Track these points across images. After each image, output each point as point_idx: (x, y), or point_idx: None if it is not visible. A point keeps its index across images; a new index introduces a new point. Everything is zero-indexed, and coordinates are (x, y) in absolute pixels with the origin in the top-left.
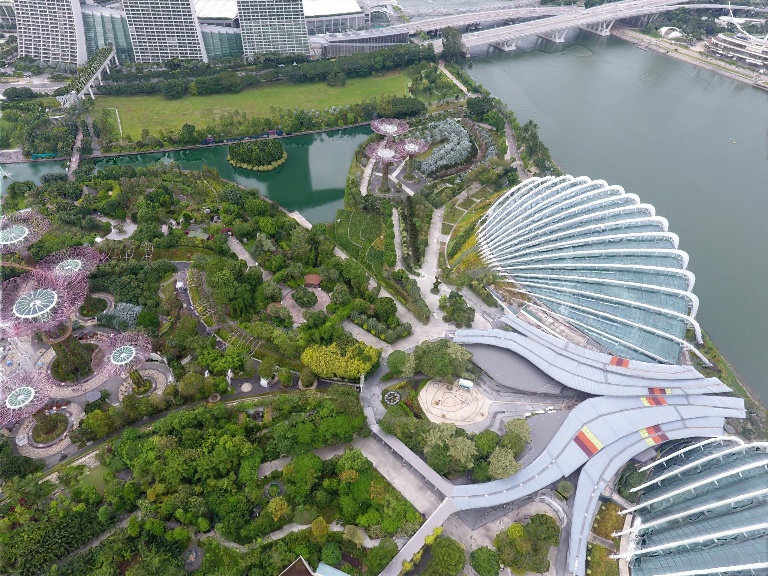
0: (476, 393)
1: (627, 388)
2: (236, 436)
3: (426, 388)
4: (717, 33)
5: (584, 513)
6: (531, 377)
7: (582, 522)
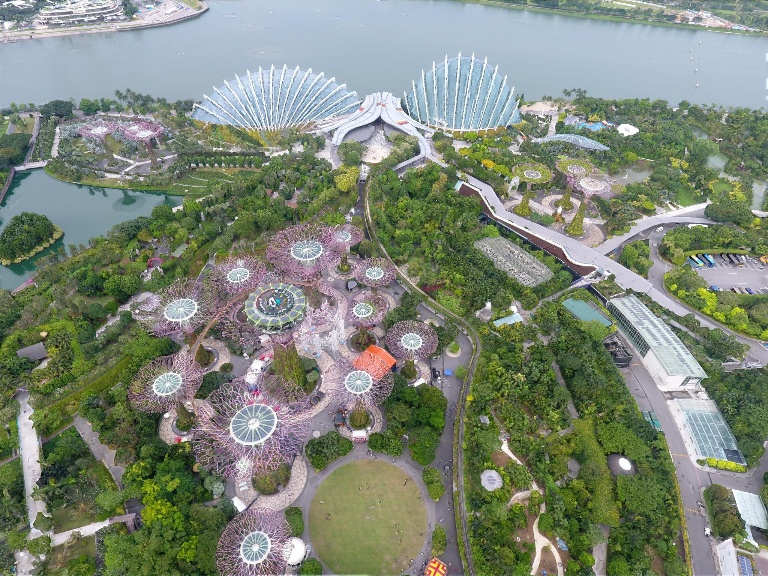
0: (370, 148)
1: (377, 109)
2: (399, 201)
3: (365, 161)
4: (24, 15)
5: (431, 130)
6: (365, 131)
7: (434, 131)
